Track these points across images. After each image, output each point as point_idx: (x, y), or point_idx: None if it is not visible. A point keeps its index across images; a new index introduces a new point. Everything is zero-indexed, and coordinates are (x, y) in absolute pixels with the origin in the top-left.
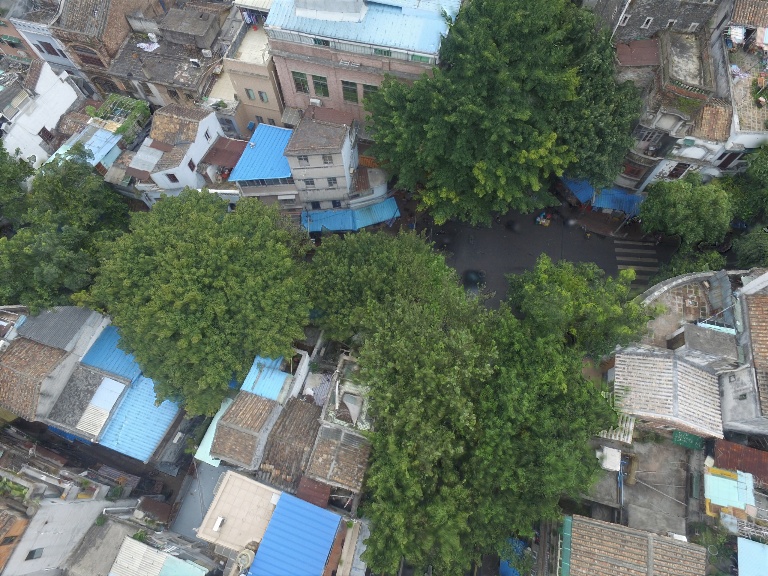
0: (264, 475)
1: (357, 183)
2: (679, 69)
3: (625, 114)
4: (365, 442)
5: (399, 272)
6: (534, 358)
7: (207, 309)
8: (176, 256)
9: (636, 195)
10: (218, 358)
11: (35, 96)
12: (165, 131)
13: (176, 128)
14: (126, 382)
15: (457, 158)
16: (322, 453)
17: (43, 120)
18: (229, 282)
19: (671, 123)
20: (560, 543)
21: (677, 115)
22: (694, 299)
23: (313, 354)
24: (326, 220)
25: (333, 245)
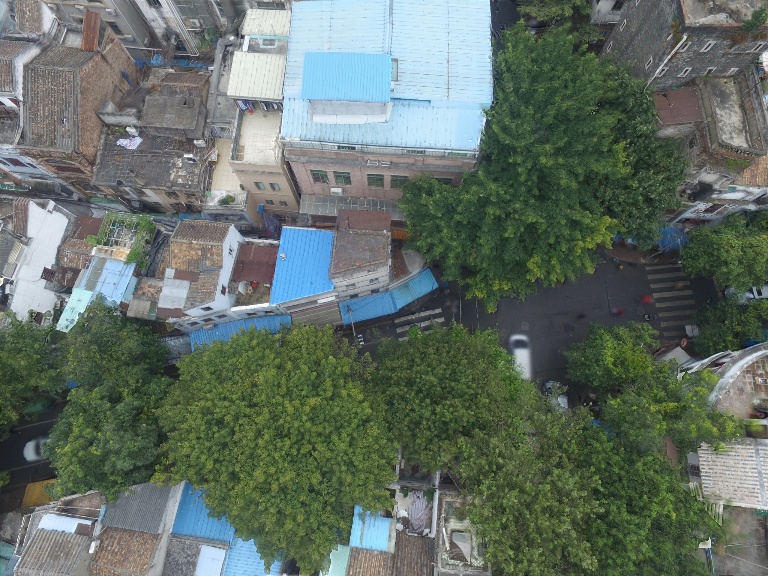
0: None
1: (394, 269)
2: (723, 125)
3: (671, 177)
4: (481, 575)
5: (482, 401)
6: (632, 477)
7: (302, 480)
8: (256, 431)
9: (668, 227)
10: (321, 521)
11: (28, 240)
12: (186, 259)
13: (198, 254)
14: (225, 547)
15: (511, 256)
16: None
17: (42, 261)
18: (316, 446)
19: (715, 177)
20: None
21: (725, 175)
22: (763, 376)
23: (396, 471)
24: (366, 307)
25: (406, 376)
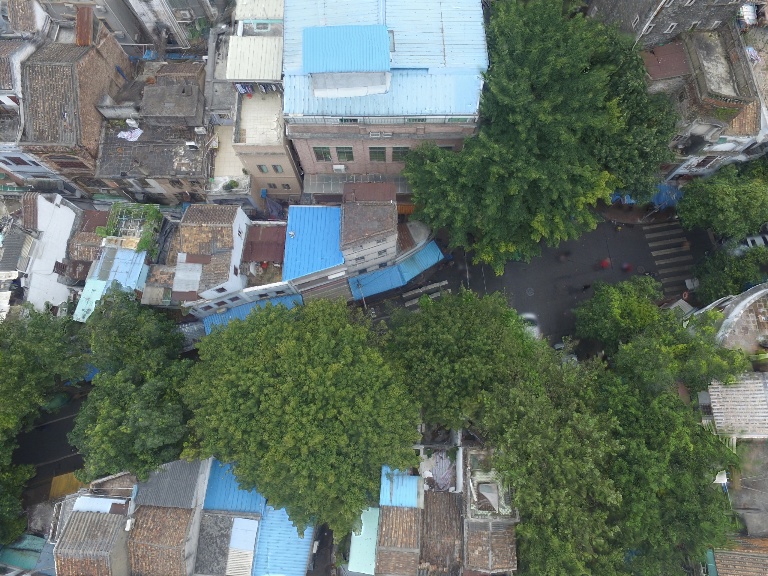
0: (421, 572)
1: (401, 241)
2: (711, 76)
3: (664, 131)
4: (509, 523)
5: (498, 356)
6: (648, 416)
7: (330, 443)
8: (282, 399)
9: (662, 185)
10: (351, 483)
11: (39, 234)
12: (197, 242)
13: (208, 237)
14: (257, 517)
15: (515, 216)
16: (476, 545)
17: (53, 255)
18: (341, 410)
19: (706, 129)
20: (703, 570)
21: (716, 125)
22: (766, 314)
23: None
24: (375, 282)
25: (422, 339)
